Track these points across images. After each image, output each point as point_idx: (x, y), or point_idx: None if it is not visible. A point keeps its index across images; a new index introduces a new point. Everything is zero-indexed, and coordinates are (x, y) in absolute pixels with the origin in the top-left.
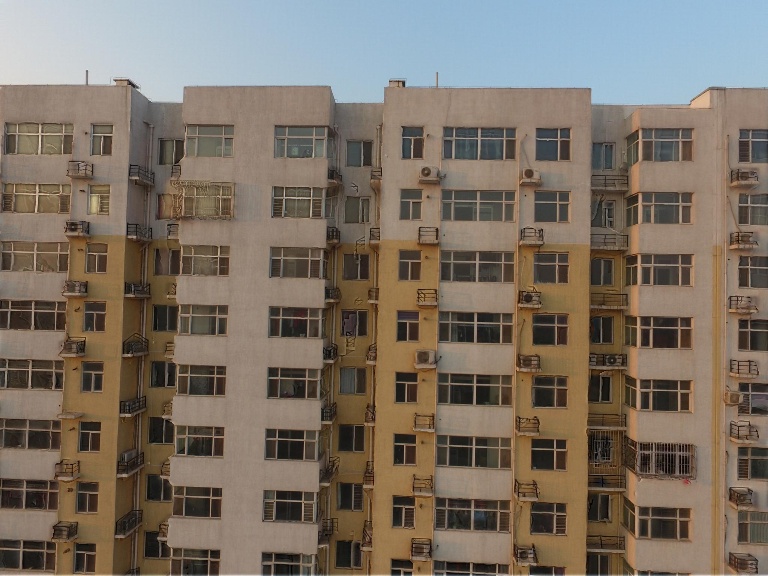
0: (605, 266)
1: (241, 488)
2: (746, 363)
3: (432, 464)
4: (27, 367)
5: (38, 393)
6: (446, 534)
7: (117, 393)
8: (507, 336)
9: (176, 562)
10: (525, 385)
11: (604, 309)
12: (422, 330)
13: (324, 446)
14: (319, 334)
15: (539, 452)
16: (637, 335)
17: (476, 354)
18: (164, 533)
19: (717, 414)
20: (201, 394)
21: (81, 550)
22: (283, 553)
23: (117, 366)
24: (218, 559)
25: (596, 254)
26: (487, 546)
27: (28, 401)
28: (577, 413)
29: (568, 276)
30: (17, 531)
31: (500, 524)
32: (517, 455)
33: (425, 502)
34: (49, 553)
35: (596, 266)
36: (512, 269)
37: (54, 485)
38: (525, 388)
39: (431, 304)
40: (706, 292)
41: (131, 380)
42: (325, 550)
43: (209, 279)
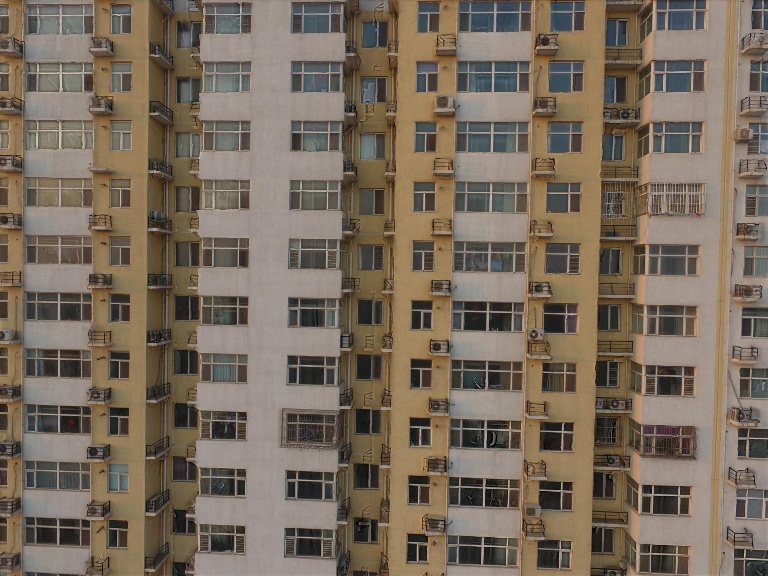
0: (620, 27)
1: (267, 237)
2: (757, 98)
3: (451, 209)
4: (57, 128)
5: (69, 152)
6: (464, 275)
7: (145, 150)
8: (524, 86)
9: (207, 309)
10: (541, 131)
11: (619, 64)
12: (441, 80)
13: (345, 208)
14: (340, 88)
15: (554, 196)
16: (651, 81)
17: (493, 102)
18: (194, 283)
19: (727, 153)
20: (226, 150)
21: (116, 302)
22: (308, 298)
23: (144, 124)
24: (246, 306)
25: (611, 14)
26: (503, 286)
27: (59, 160)
28: (591, 156)
29: (584, 23)
30: (54, 284)
31: (516, 265)
32: (533, 198)
33: (444, 246)
34: (85, 304)
35: (611, 27)
36: (529, 19)
37: (88, 241)
38: (541, 134)
39: (450, 48)
40: (720, 34)
41: (157, 147)
42: (347, 307)
43: (232, 36)
